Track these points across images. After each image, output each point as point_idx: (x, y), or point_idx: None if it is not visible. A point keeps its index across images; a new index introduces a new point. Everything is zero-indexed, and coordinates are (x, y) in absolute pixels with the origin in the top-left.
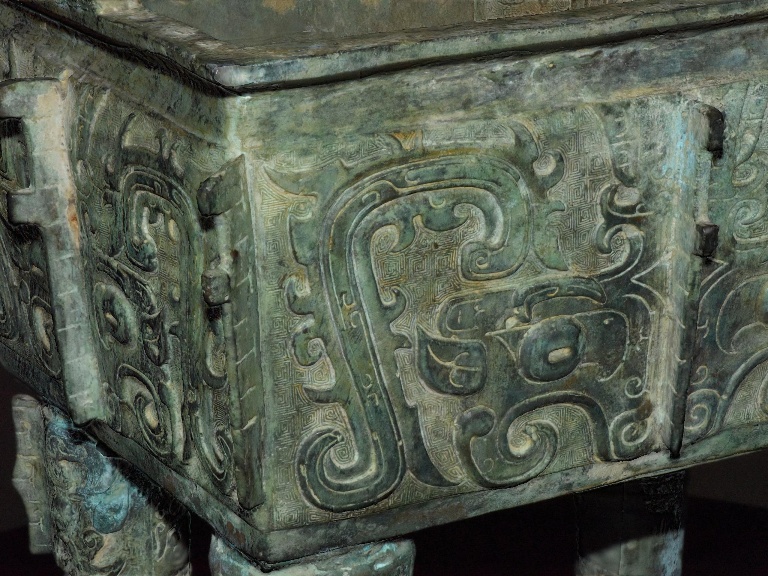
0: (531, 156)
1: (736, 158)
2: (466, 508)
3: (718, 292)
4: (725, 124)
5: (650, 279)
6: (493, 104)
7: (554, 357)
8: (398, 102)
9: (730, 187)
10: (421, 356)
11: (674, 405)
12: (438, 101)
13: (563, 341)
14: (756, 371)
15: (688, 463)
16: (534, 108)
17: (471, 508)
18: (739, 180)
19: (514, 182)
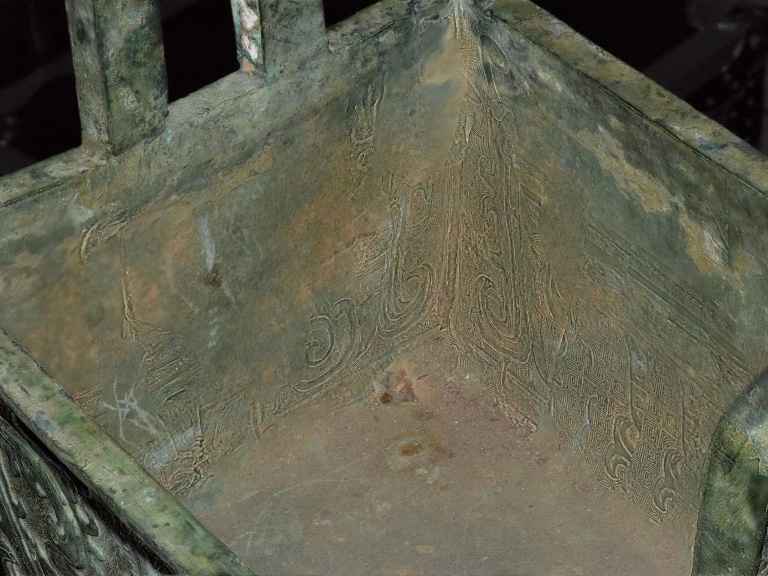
0: None
1: None
2: None
3: None
4: None
5: None
6: None
7: None
8: None
9: None
10: None
11: None
12: None
13: None
14: None
15: None
16: None
17: None
18: None
19: (60, 503)
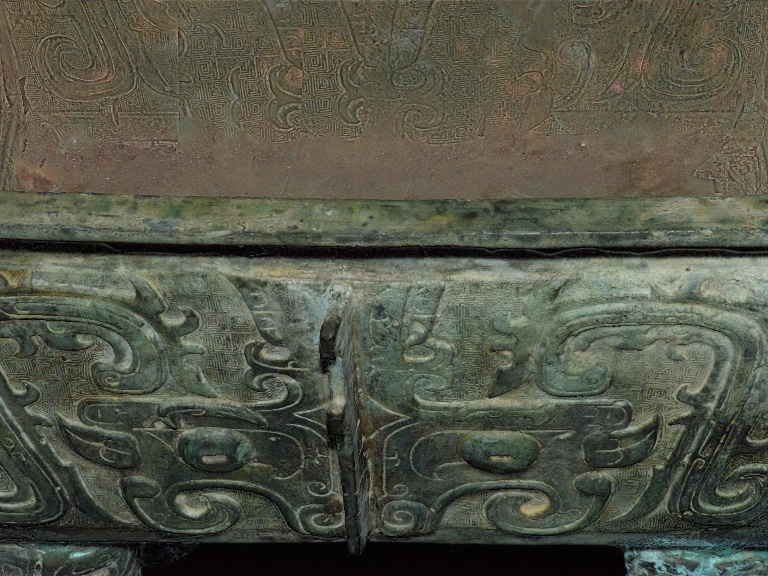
0: (155, 309)
1: (405, 341)
2: (155, 536)
3: (405, 436)
4: (385, 314)
5: (317, 417)
6: (117, 257)
7: (211, 458)
8: (8, 243)
9: (401, 362)
10: (63, 435)
11: (345, 521)
12: (54, 246)
13: (216, 450)
14: (474, 494)
15: (414, 541)
16: (162, 267)
17: (161, 536)
18: (415, 356)
19: (136, 328)
